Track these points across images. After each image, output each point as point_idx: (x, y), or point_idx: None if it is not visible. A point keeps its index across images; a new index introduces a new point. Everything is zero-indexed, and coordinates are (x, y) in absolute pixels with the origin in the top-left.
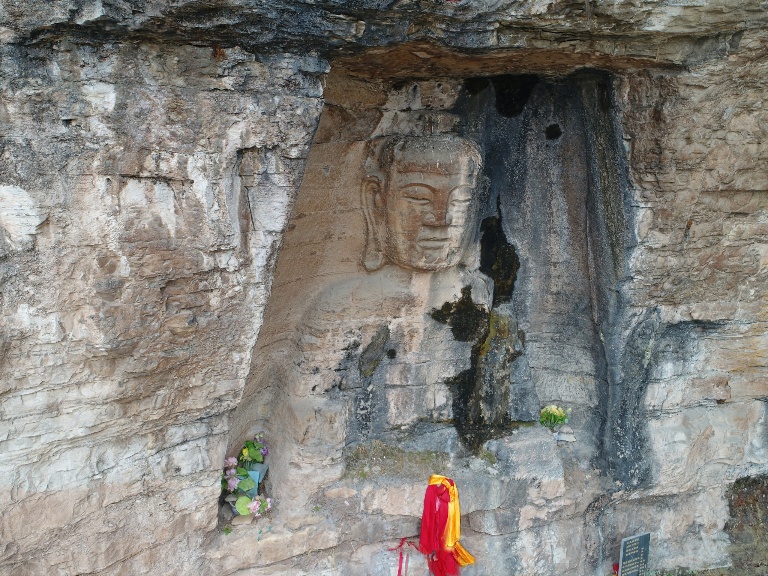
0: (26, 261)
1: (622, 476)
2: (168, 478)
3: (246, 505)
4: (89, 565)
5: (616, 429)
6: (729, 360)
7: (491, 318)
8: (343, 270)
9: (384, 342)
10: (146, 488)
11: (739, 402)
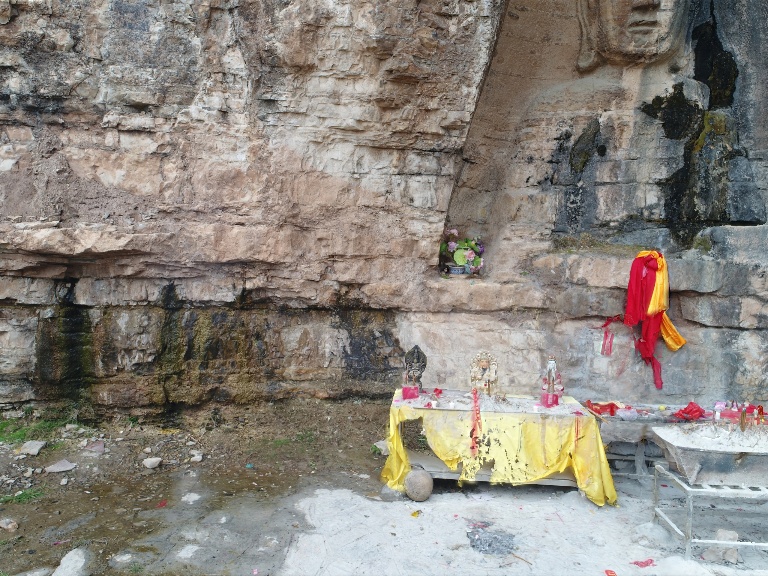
0: None
1: None
2: (404, 204)
3: (463, 252)
4: (342, 247)
5: None
6: None
7: (705, 115)
8: (559, 77)
9: (594, 134)
10: (388, 204)
11: None
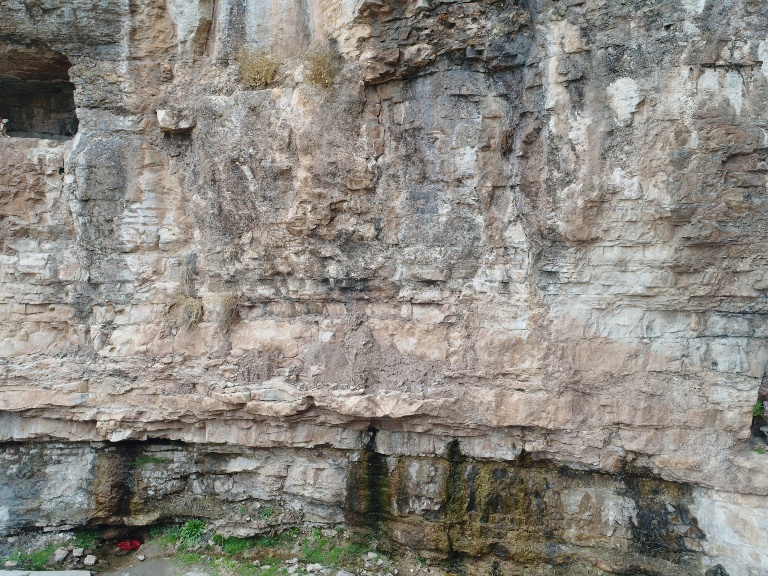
0: (625, 134)
1: None
2: (705, 369)
3: None
4: (629, 416)
5: None
6: None
7: None
8: None
9: None
10: (684, 369)
11: None
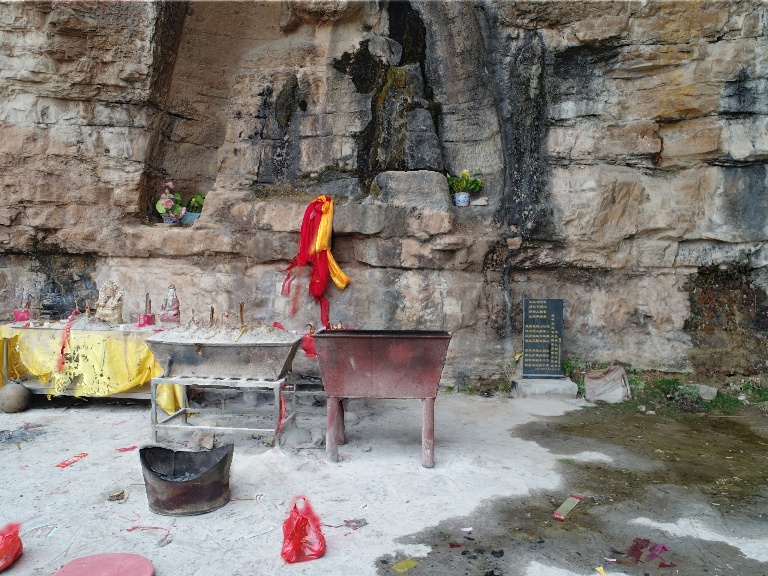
0: None
1: (515, 218)
2: (99, 155)
3: (161, 201)
4: (29, 193)
5: (513, 174)
6: (651, 104)
7: (389, 70)
8: (270, 37)
9: (293, 89)
10: (80, 154)
11: (688, 169)
